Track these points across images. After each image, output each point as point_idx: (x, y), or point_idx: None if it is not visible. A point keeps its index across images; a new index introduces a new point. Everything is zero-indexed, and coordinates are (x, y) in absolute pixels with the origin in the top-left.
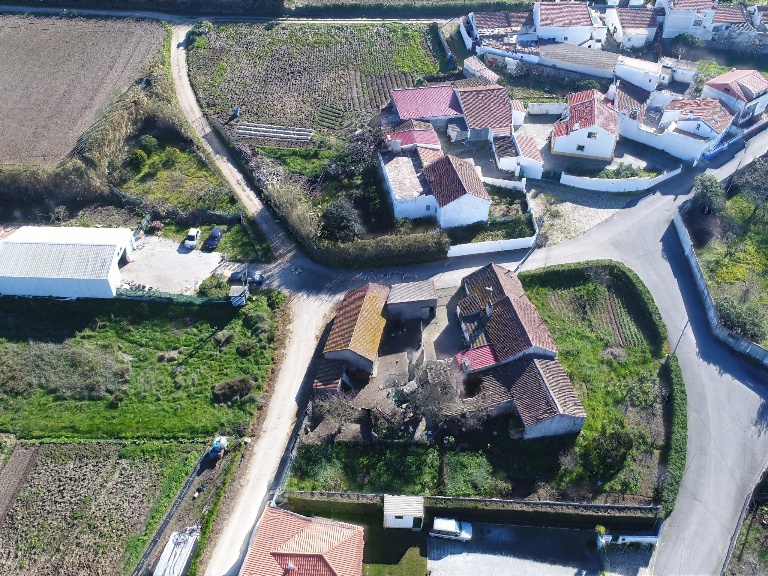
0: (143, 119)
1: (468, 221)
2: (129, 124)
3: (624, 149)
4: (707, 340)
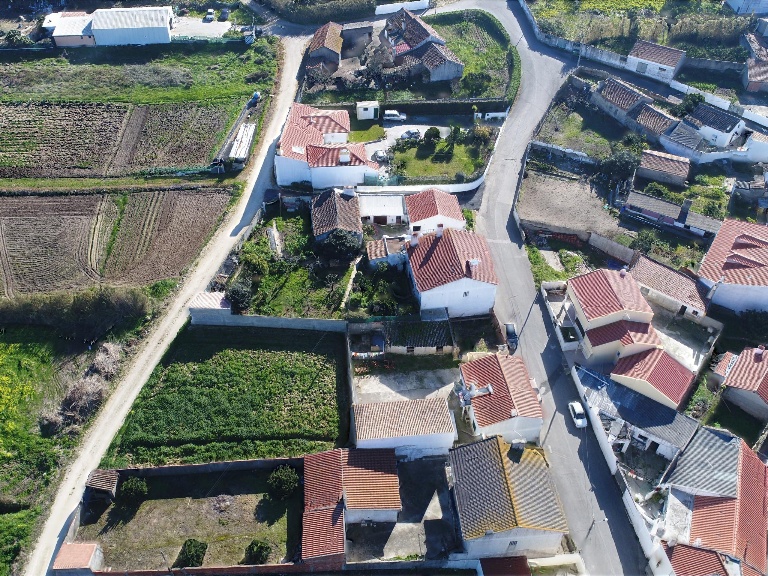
0: None
1: None
2: None
3: None
4: (534, 42)
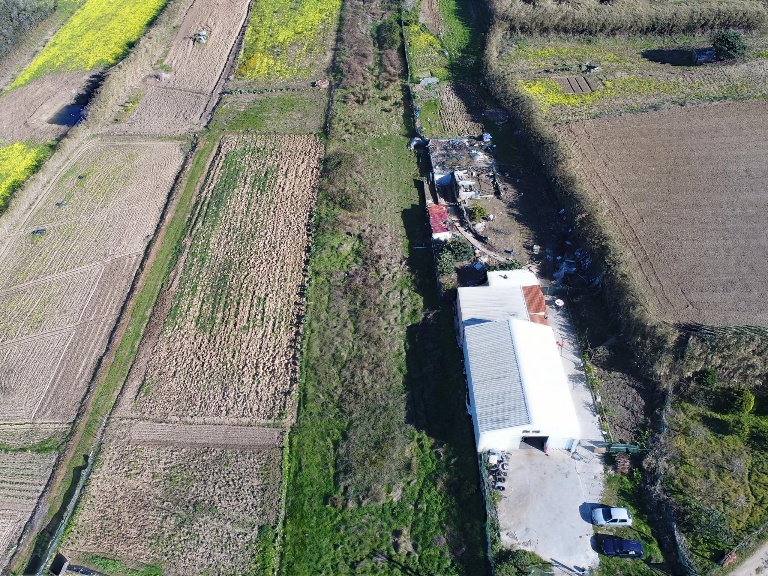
0: None
1: None
2: None
3: None
4: None
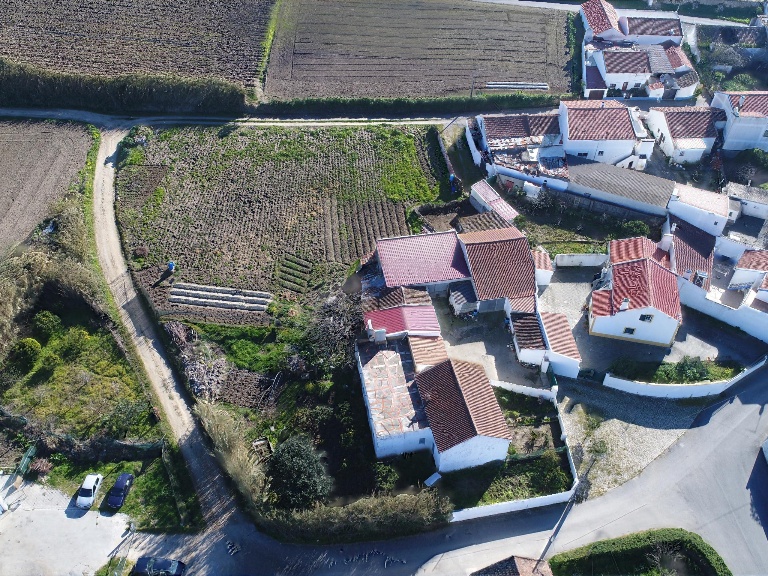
0: (42, 285)
1: (478, 462)
2: (19, 299)
3: (686, 326)
4: None
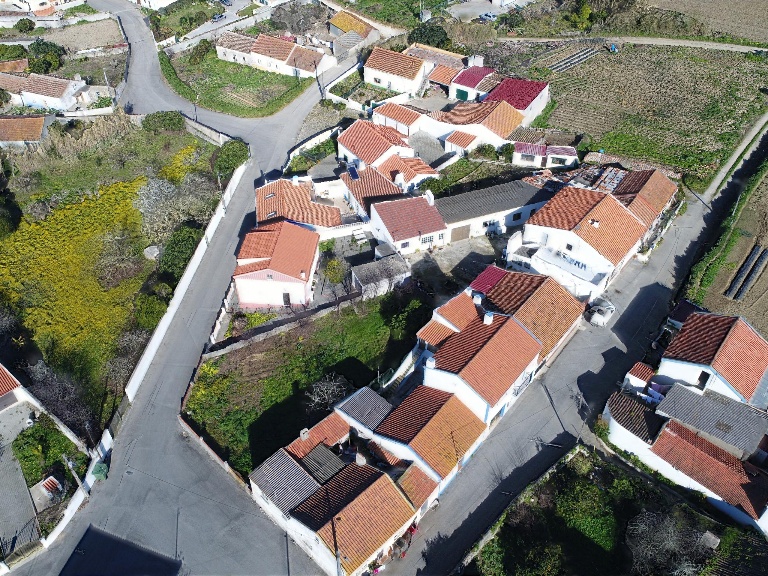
0: None
1: None
2: (616, 1)
3: None
4: None
